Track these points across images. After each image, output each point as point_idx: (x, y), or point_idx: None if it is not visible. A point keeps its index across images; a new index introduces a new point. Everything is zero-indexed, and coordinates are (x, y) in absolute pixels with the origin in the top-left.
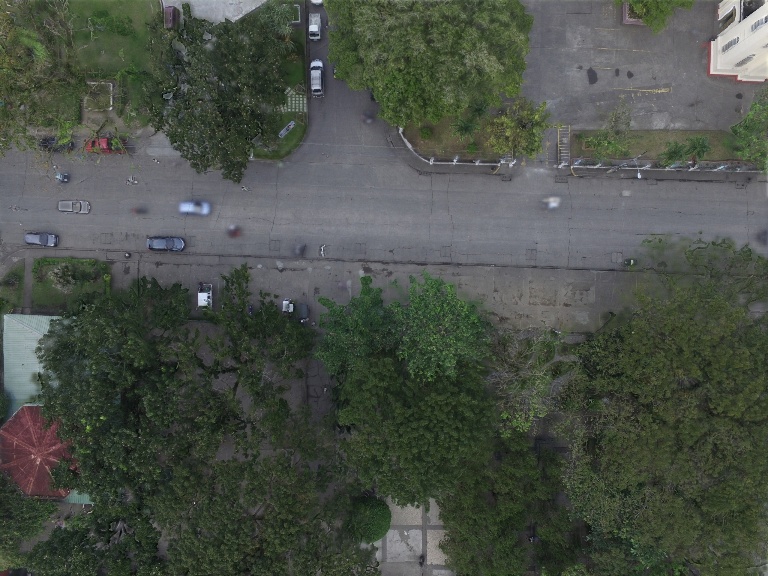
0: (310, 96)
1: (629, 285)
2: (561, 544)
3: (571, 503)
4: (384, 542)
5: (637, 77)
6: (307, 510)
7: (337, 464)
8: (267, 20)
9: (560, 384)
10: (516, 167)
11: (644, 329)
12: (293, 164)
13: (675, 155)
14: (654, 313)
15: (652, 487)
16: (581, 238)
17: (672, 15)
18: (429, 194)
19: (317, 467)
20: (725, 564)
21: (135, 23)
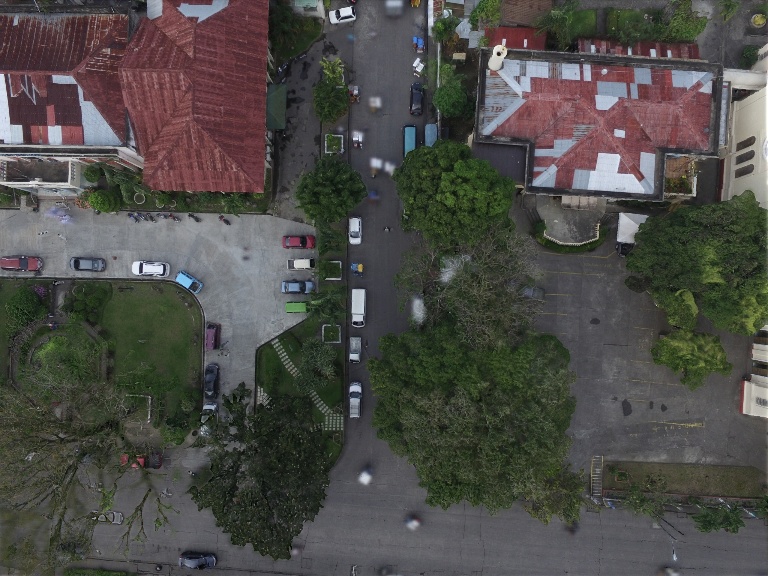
0: (347, 415)
1: None
2: None
3: None
4: None
5: (671, 410)
6: None
7: None
8: (310, 361)
9: None
10: None
11: None
12: None
13: (709, 527)
14: None
15: None
16: (611, 569)
17: None
18: (462, 518)
19: None
20: None
21: (176, 335)
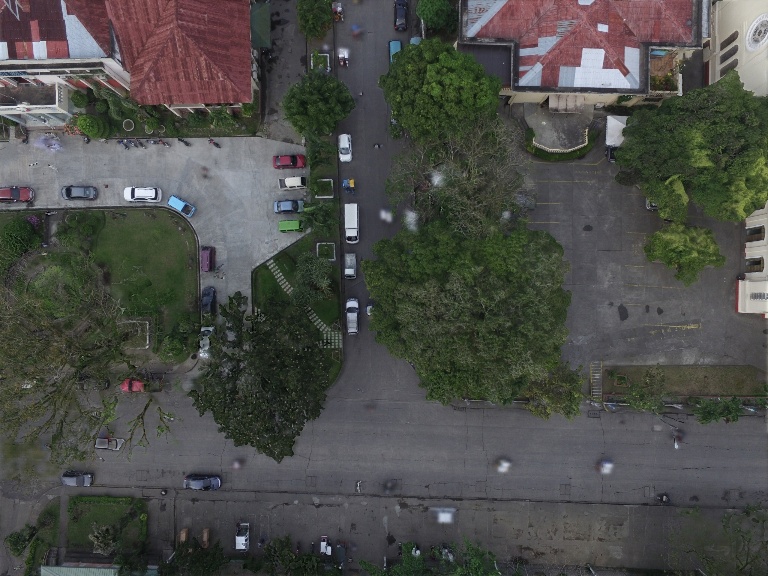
0: (345, 332)
1: (662, 519)
2: None
3: None
4: None
5: (667, 313)
6: None
7: None
8: (305, 274)
9: None
10: None
11: None
12: (329, 400)
13: (709, 417)
14: None
15: None
16: (614, 473)
17: None
18: (464, 430)
19: None
20: None
21: (171, 260)
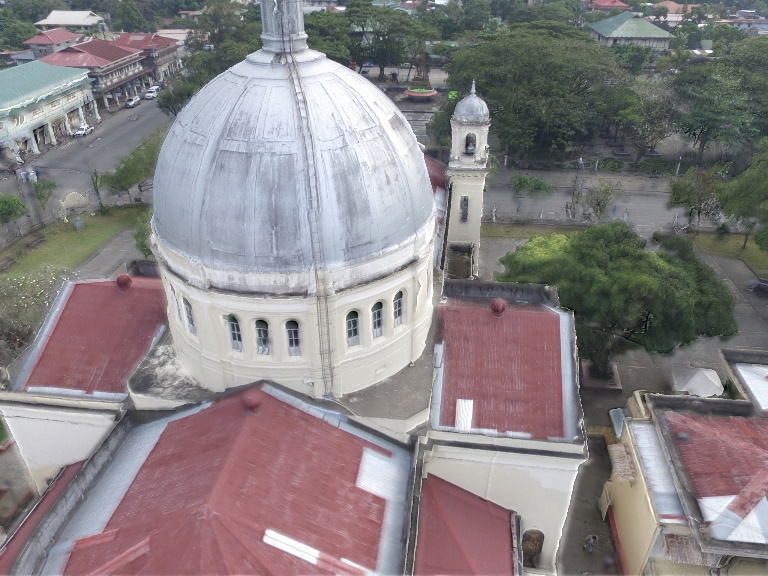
0: None
1: None
2: (590, 88)
3: None
4: None
5: None
6: None
7: None
8: None
9: None
10: None
11: None
12: None
13: None
14: None
15: None
16: None
17: None
18: None
19: None
20: None
21: None
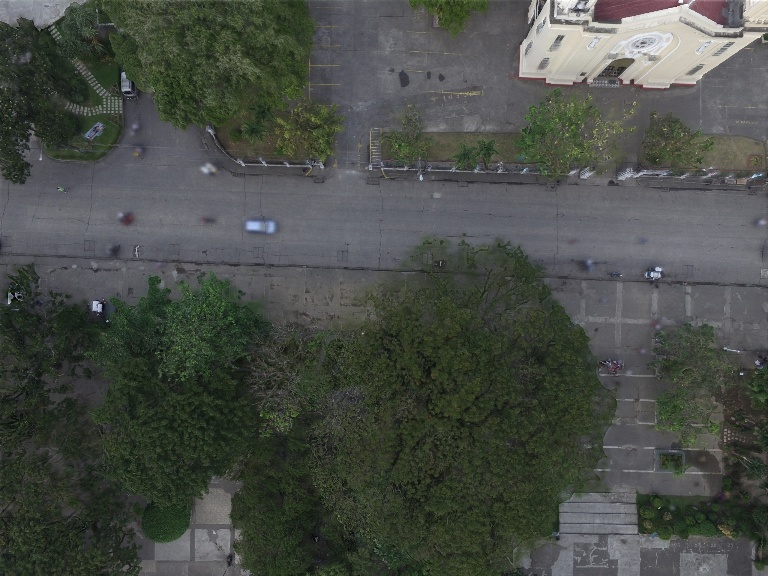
0: (126, 98)
1: None
2: (340, 544)
3: (322, 503)
4: (192, 541)
5: (448, 80)
6: (59, 508)
7: (102, 463)
8: (70, 22)
9: (309, 384)
10: (328, 169)
11: (373, 330)
12: (108, 165)
13: (463, 157)
14: (385, 314)
15: (377, 487)
16: (392, 240)
17: (483, 18)
18: (242, 195)
19: (82, 466)
20: (452, 564)
21: None
